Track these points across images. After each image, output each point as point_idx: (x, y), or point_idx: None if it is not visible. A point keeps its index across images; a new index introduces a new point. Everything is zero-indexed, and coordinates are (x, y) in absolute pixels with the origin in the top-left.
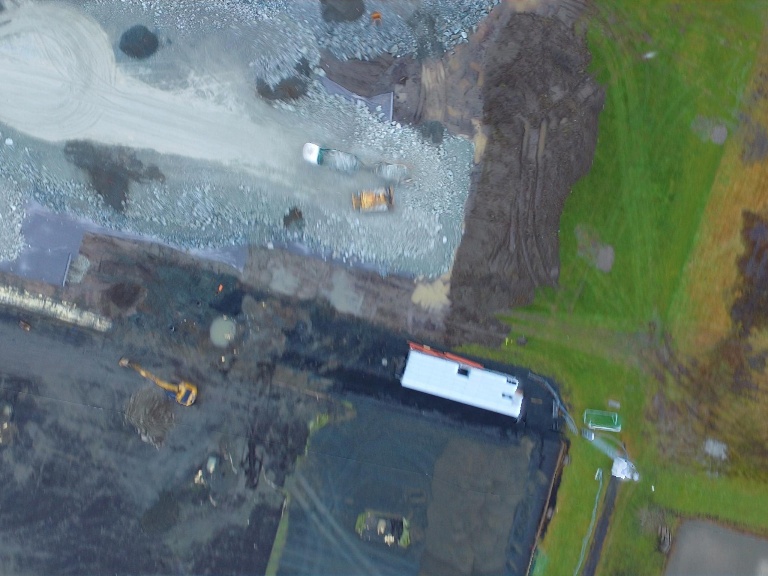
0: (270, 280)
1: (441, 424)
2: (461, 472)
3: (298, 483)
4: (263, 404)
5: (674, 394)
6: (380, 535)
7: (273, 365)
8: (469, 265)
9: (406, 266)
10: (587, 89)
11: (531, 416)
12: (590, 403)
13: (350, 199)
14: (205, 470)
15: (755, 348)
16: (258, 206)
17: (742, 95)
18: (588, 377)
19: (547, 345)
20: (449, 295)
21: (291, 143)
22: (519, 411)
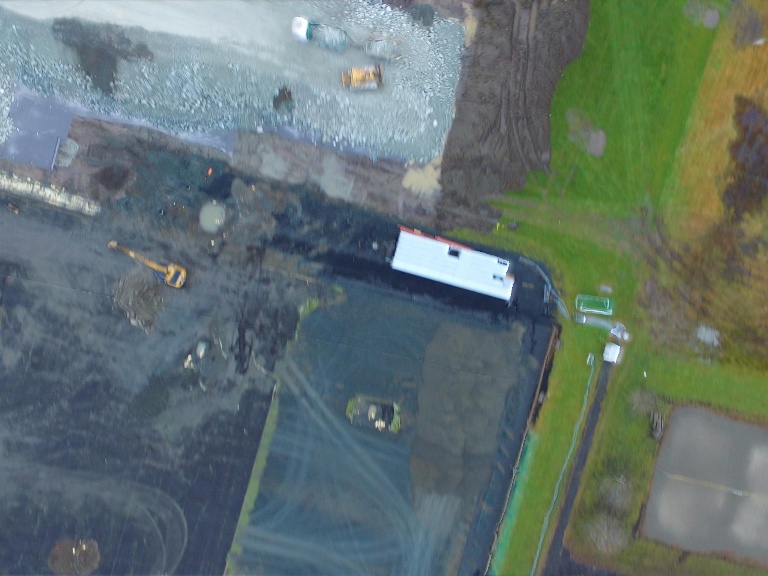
0: (260, 165)
1: (432, 308)
2: (452, 353)
3: (288, 368)
4: (253, 288)
5: (666, 280)
6: (371, 420)
7: (263, 249)
8: (460, 148)
9: (396, 150)
10: None
11: (522, 300)
12: (582, 288)
13: (340, 77)
14: (195, 355)
15: (747, 234)
16: (247, 87)
17: None
18: (580, 262)
19: (538, 230)
20: (440, 180)
21: (280, 21)
22: (510, 293)
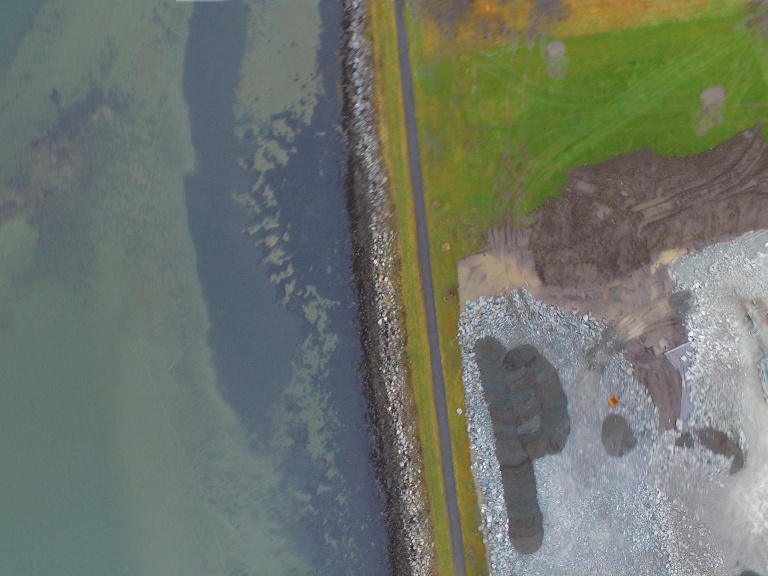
0: None
1: None
2: None
3: None
4: None
5: None
6: None
7: None
8: None
9: None
10: (581, 187)
11: None
12: None
13: None
14: None
15: None
16: None
17: (512, 46)
18: None
19: None
20: None
21: None
22: None
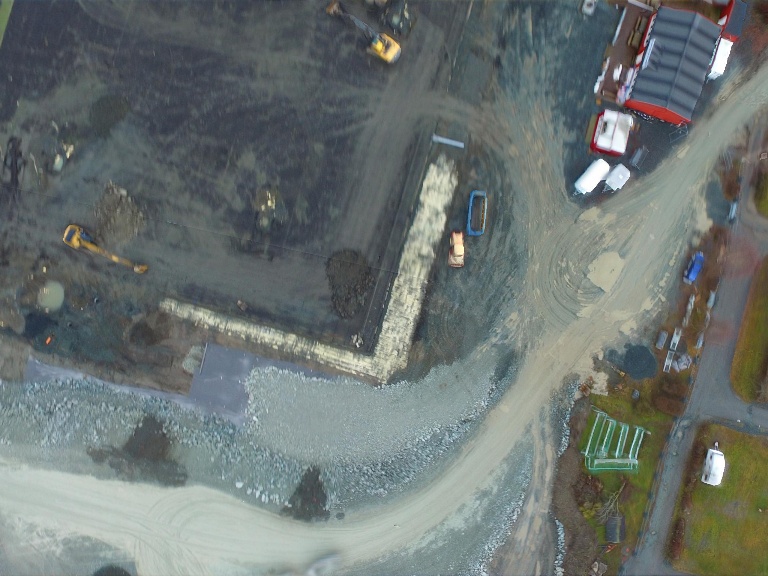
0: (2, 347)
1: None
2: None
3: None
4: (4, 224)
5: None
6: None
7: None
8: None
9: None
10: None
11: None
12: None
13: None
14: (65, 158)
15: None
16: (3, 423)
17: None
18: None
19: None
20: None
21: None
22: None
